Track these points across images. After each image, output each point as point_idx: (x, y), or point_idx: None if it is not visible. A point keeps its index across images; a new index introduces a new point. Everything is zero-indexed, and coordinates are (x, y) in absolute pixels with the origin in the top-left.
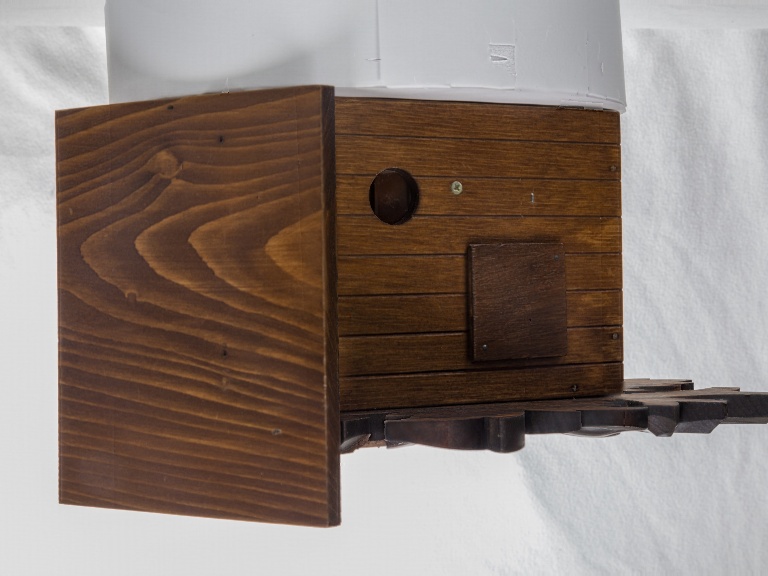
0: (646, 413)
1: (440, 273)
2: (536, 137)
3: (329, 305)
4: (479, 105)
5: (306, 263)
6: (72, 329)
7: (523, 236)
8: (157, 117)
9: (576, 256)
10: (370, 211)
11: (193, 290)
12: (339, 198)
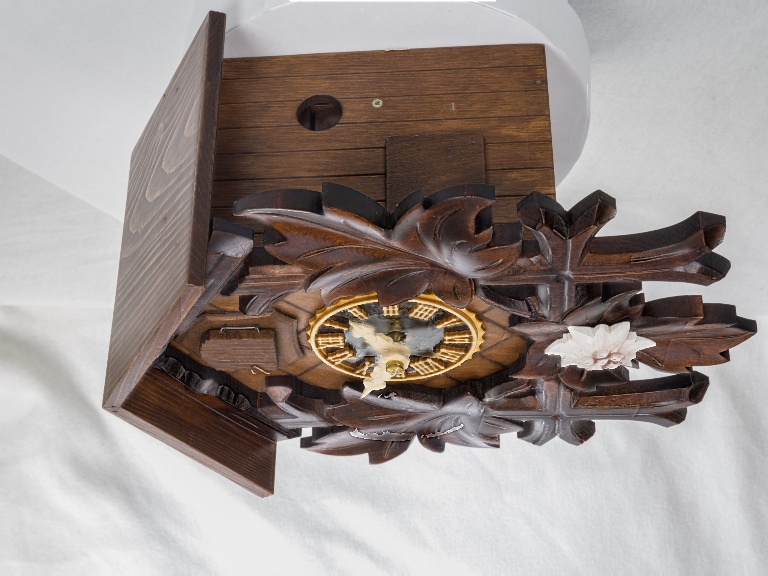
0: (492, 188)
1: (360, 161)
2: (457, 66)
3: (204, 139)
4: (400, 50)
5: (195, 121)
6: (120, 281)
7: (444, 133)
8: (160, 107)
9: (501, 145)
10: (296, 123)
11: (159, 195)
12: (269, 116)
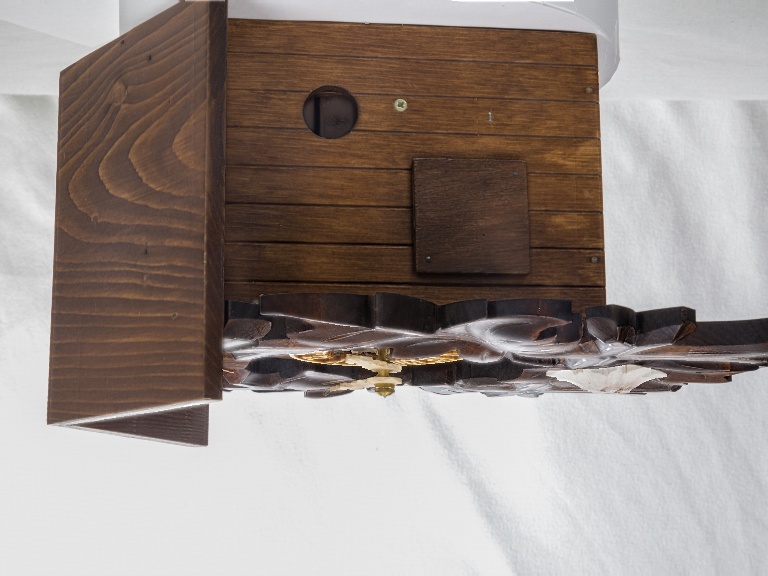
0: (568, 305)
1: (381, 187)
2: (494, 58)
3: (212, 187)
4: None
5: (196, 151)
6: (61, 261)
7: (479, 154)
8: (115, 54)
9: (544, 176)
10: (303, 125)
11: (130, 200)
12: (269, 112)
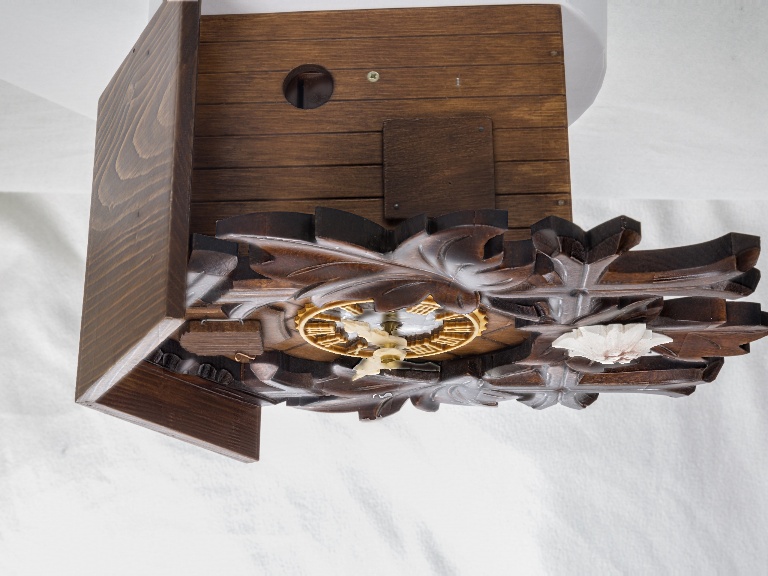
0: (504, 215)
1: (355, 148)
2: (462, 32)
3: (181, 136)
4: (399, 10)
5: (170, 110)
6: (90, 256)
7: (448, 115)
8: (129, 63)
9: (511, 131)
10: (283, 99)
11: (131, 178)
12: (252, 90)
